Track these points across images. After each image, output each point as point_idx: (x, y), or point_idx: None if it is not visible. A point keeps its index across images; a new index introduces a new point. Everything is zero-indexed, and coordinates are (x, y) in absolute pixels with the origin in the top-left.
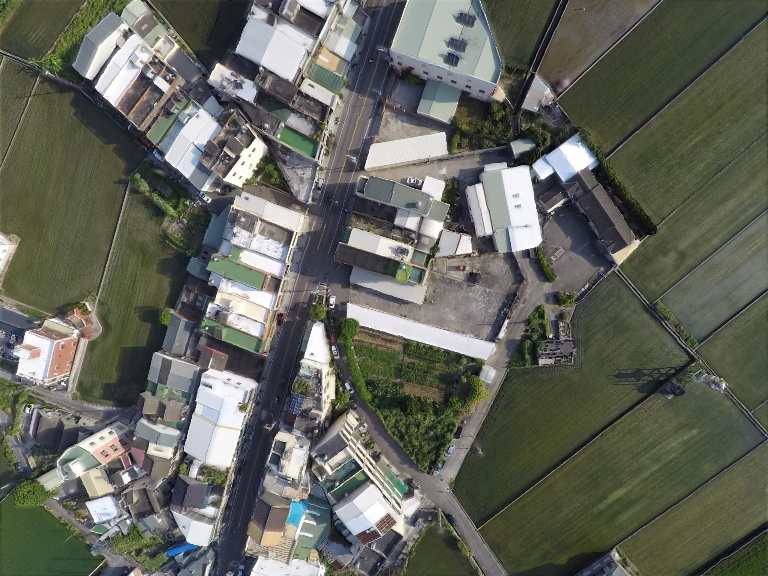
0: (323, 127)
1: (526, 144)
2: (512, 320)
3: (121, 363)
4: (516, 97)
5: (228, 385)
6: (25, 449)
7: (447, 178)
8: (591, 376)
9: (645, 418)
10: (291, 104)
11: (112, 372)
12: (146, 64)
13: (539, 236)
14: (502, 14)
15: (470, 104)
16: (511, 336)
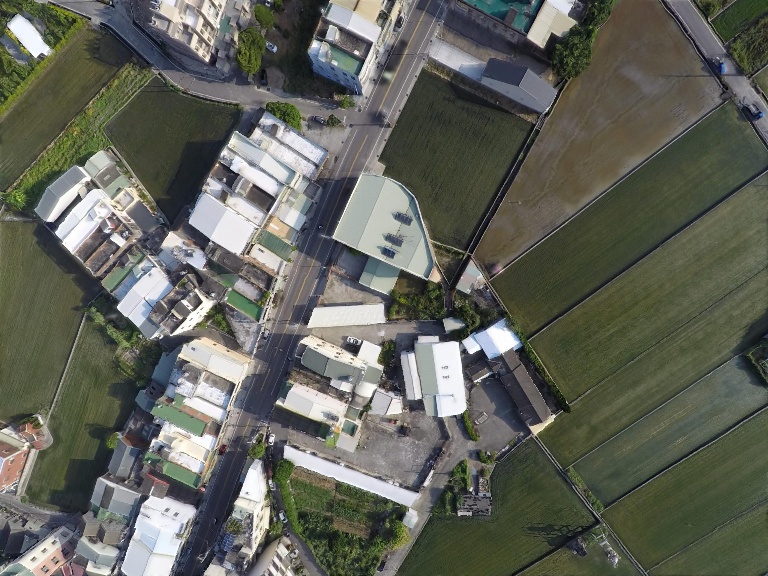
0: (268, 296)
1: (457, 323)
2: (437, 471)
3: (70, 473)
4: (453, 274)
5: (166, 516)
6: None
7: (385, 340)
8: (506, 527)
9: (552, 568)
10: (239, 273)
11: (61, 480)
12: (104, 219)
13: (464, 404)
14: (445, 198)
15: (410, 276)
16: (435, 484)
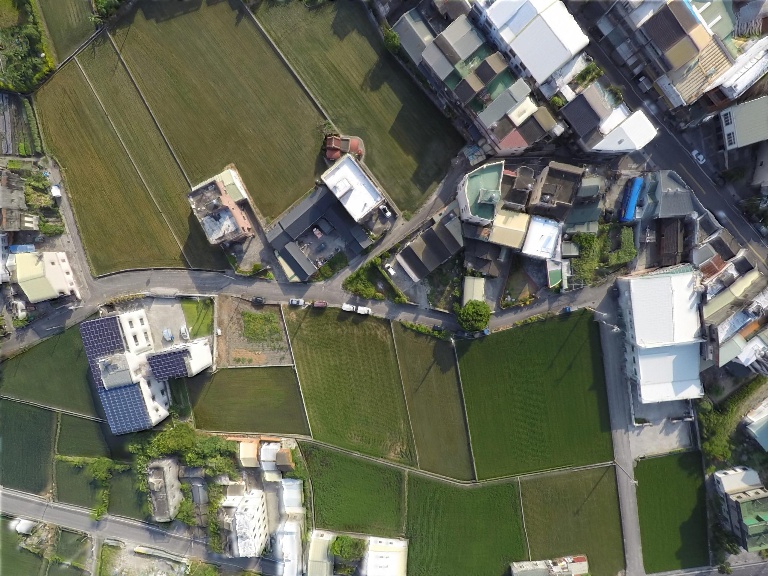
0: None
1: None
2: None
3: (404, 144)
4: None
5: None
6: (425, 311)
7: None
8: None
9: None
10: None
11: (406, 160)
12: None
13: None
14: None
15: None
16: None
